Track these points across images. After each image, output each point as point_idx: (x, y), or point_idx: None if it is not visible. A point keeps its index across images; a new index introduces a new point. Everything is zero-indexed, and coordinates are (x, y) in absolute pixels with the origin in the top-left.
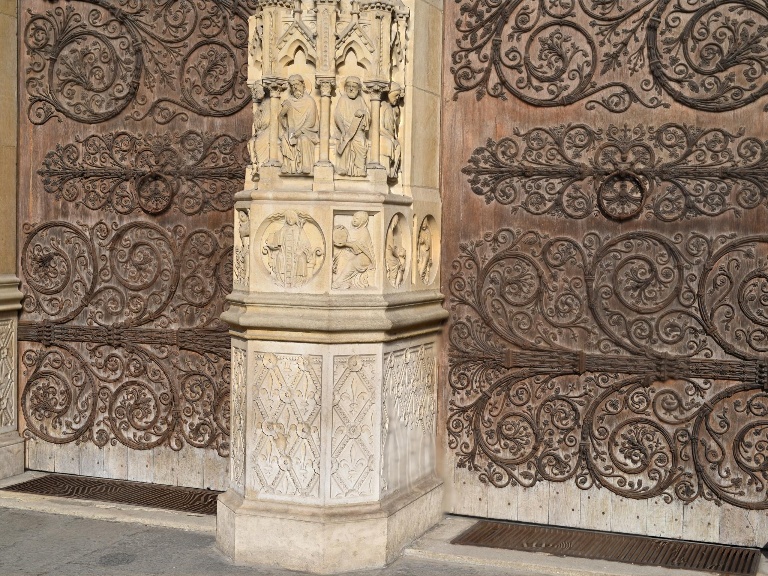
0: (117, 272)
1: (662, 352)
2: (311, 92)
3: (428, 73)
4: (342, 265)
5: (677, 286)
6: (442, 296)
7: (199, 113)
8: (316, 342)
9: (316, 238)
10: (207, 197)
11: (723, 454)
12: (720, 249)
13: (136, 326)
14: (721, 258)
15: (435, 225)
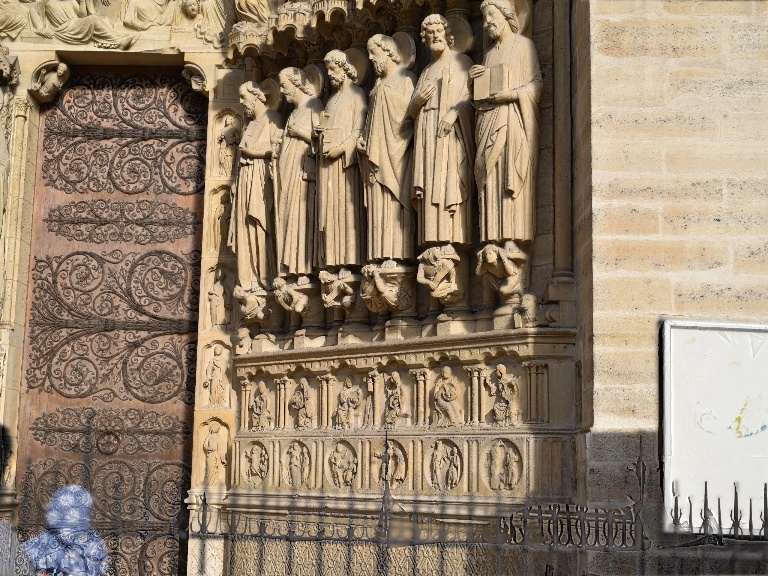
0: None
1: (125, 518)
2: None
3: (14, 380)
4: None
5: (133, 486)
6: (16, 493)
7: None
8: None
9: None
10: None
11: (153, 567)
12: (153, 468)
13: None
14: (154, 472)
15: (14, 456)
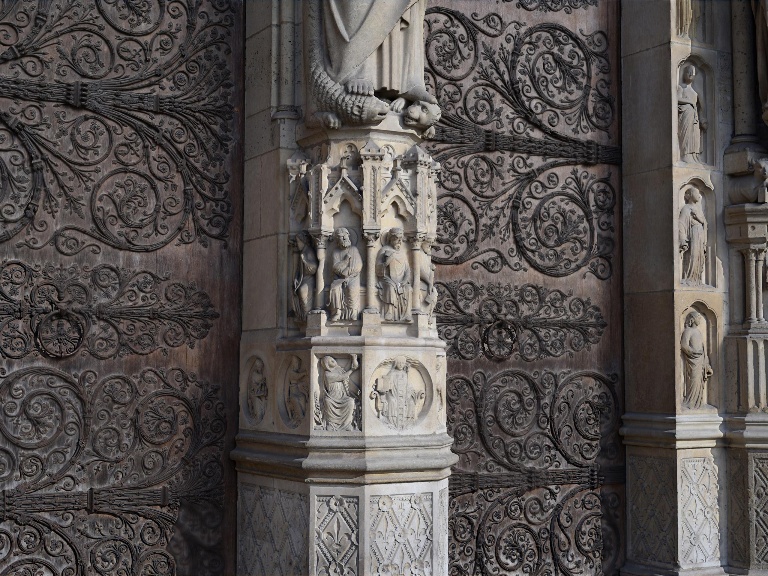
0: (5, 428)
1: (531, 467)
2: None
3: None
4: None
5: (539, 413)
6: None
7: (116, 246)
8: (430, 480)
9: (418, 382)
10: (126, 339)
11: (570, 543)
12: (563, 382)
13: (32, 492)
14: (563, 389)
15: None
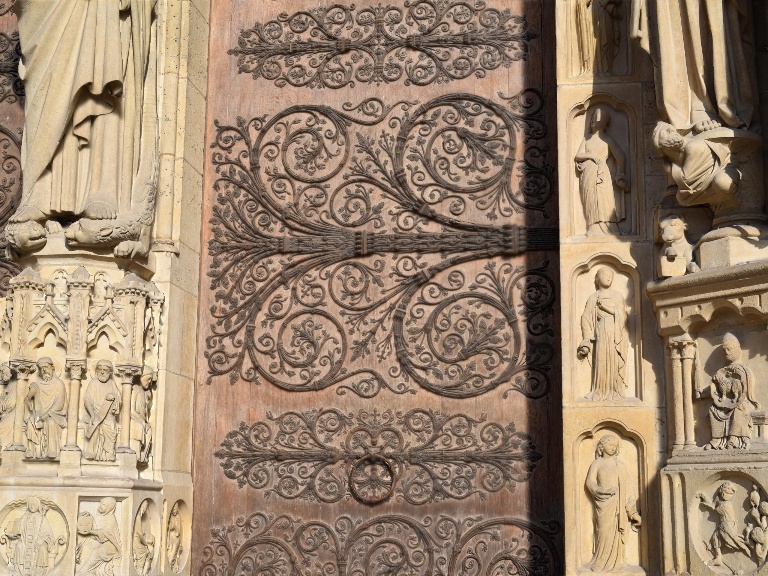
0: None
1: None
2: (60, 375)
3: (182, 357)
4: (86, 554)
5: (428, 570)
6: None
7: None
8: None
9: (59, 526)
10: None
11: None
12: (468, 532)
13: None
14: (469, 541)
15: (186, 510)
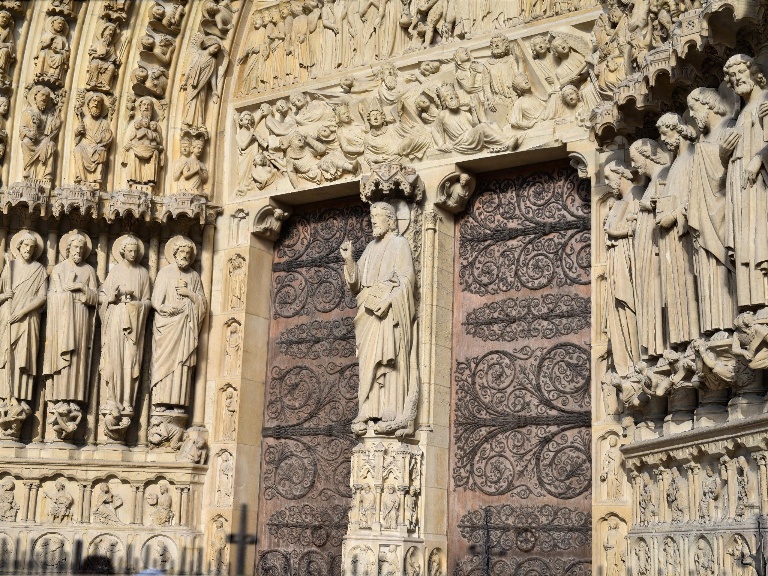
0: (301, 575)
1: None
2: (374, 491)
3: (438, 479)
4: (384, 569)
5: None
6: None
7: (341, 496)
8: None
9: (373, 557)
10: None
11: None
12: (568, 566)
13: None
14: (569, 571)
15: (443, 553)
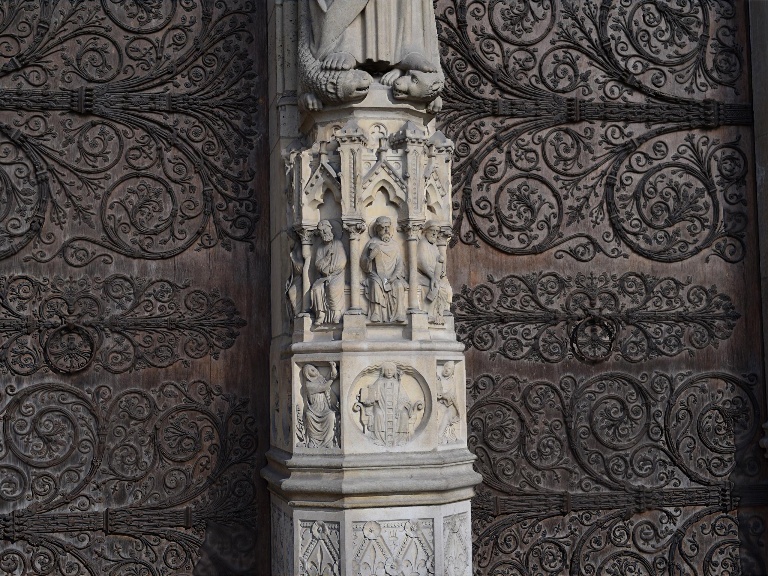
0: (15, 447)
1: (639, 485)
2: (393, 235)
3: None
4: (439, 419)
5: (648, 422)
6: None
7: (129, 255)
8: (428, 504)
9: (415, 391)
10: (141, 351)
11: (696, 575)
12: (681, 386)
13: (44, 512)
14: (681, 394)
15: None
